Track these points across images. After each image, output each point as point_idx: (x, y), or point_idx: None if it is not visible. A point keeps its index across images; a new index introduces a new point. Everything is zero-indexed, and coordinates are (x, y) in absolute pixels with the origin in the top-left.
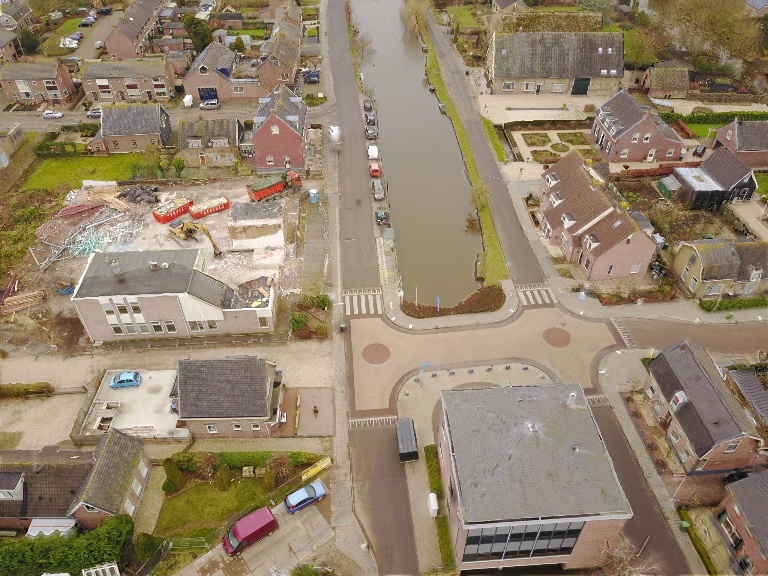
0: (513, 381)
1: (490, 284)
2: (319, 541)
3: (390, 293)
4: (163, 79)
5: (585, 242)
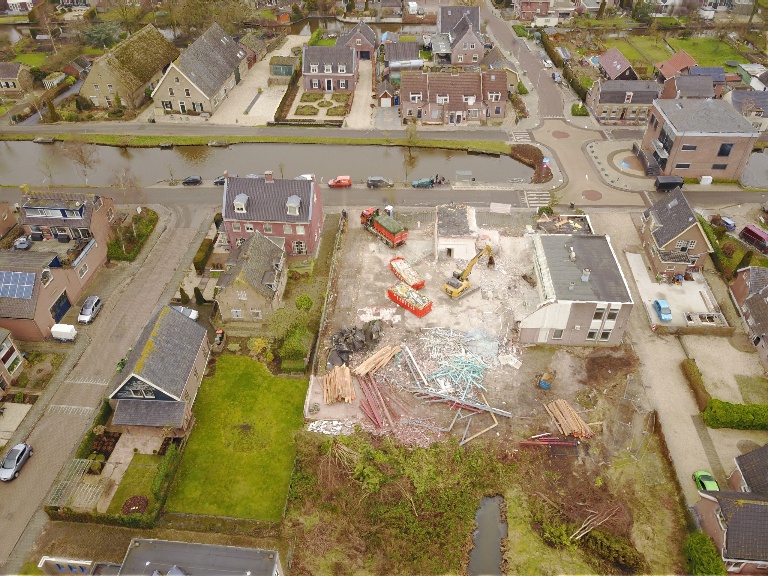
0: (602, 152)
1: (509, 150)
2: (745, 221)
3: (525, 187)
4: (8, 339)
5: (490, 99)
